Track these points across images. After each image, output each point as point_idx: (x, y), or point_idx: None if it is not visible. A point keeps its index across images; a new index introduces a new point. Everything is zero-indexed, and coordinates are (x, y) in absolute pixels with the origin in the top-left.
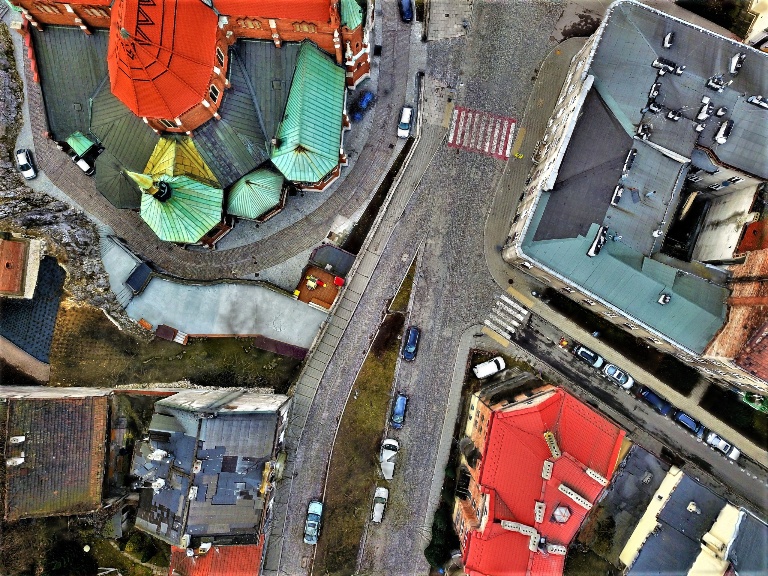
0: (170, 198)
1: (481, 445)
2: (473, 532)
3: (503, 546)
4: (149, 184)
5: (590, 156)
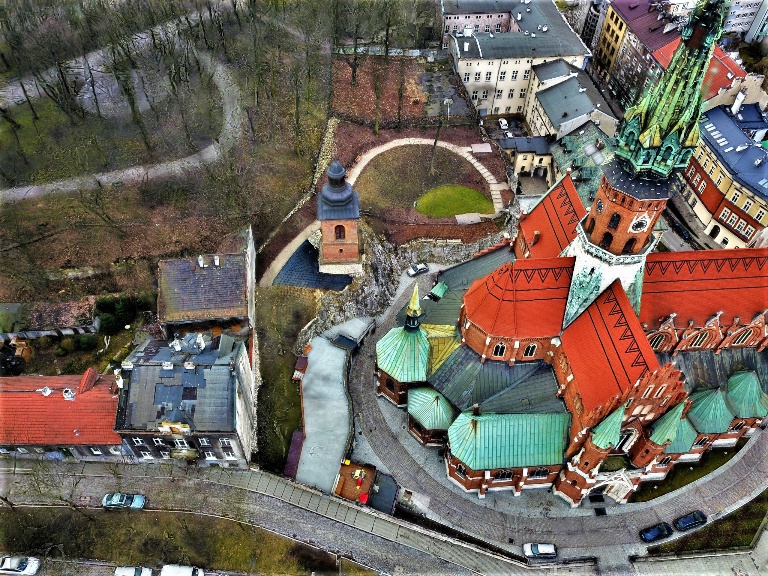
0: (408, 333)
1: None
2: None
3: None
4: (413, 307)
5: None
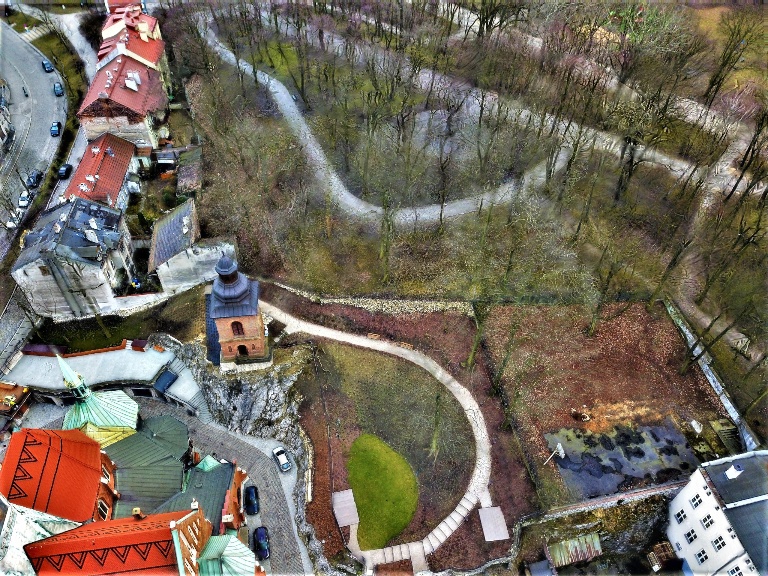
0: None
1: None
2: None
3: None
4: None
5: None
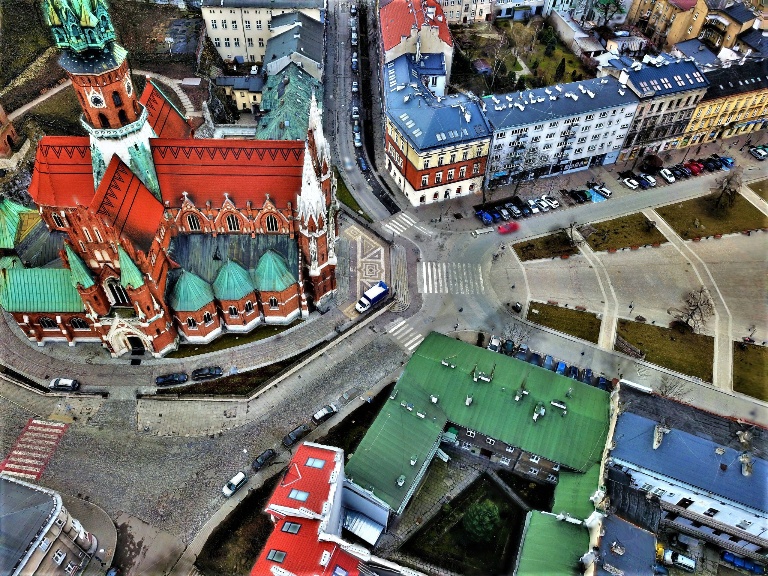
0: None
1: None
2: None
3: None
4: None
5: None
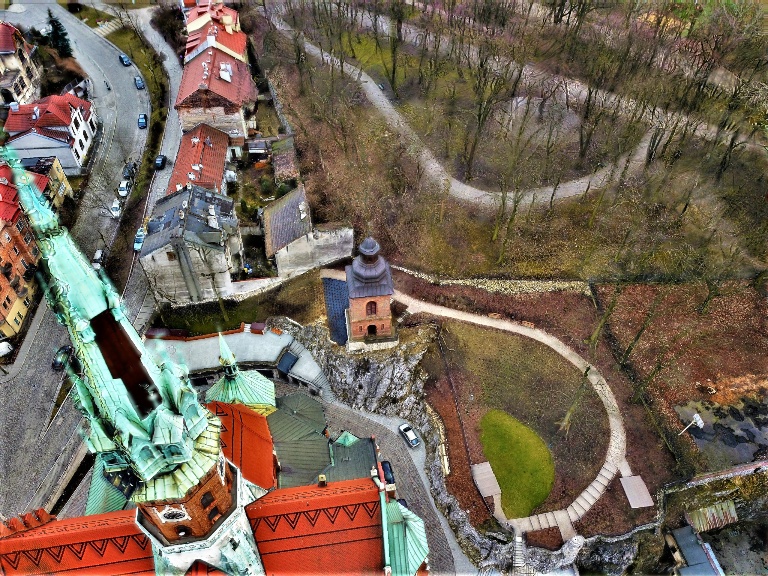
0: None
1: None
2: (8, 220)
3: None
4: None
5: None
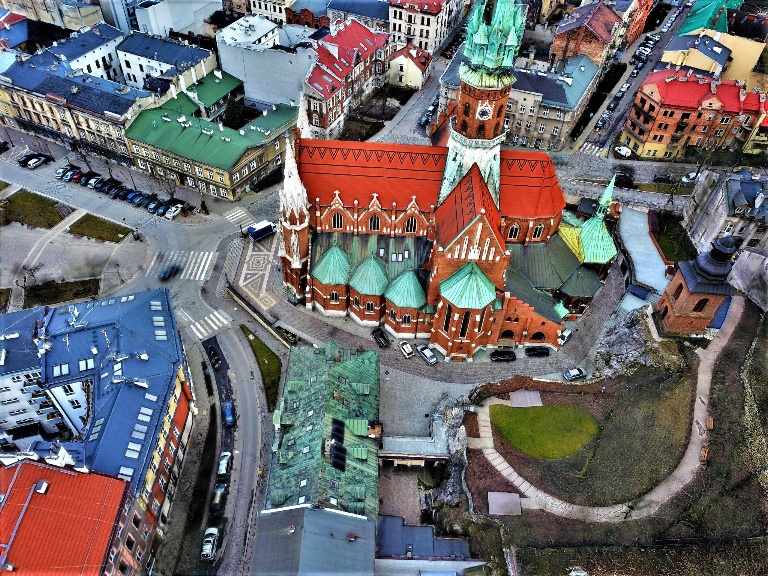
0: None
1: (676, 119)
2: (722, 108)
3: (724, 96)
4: None
5: (524, 84)
